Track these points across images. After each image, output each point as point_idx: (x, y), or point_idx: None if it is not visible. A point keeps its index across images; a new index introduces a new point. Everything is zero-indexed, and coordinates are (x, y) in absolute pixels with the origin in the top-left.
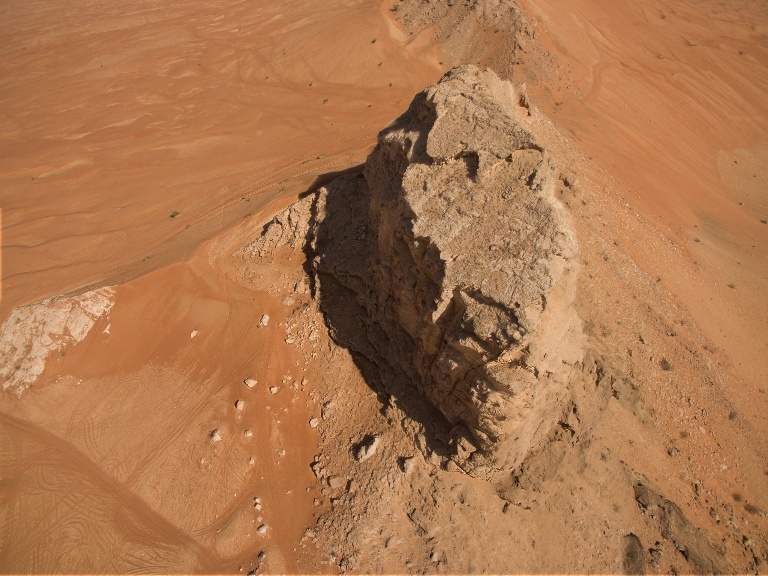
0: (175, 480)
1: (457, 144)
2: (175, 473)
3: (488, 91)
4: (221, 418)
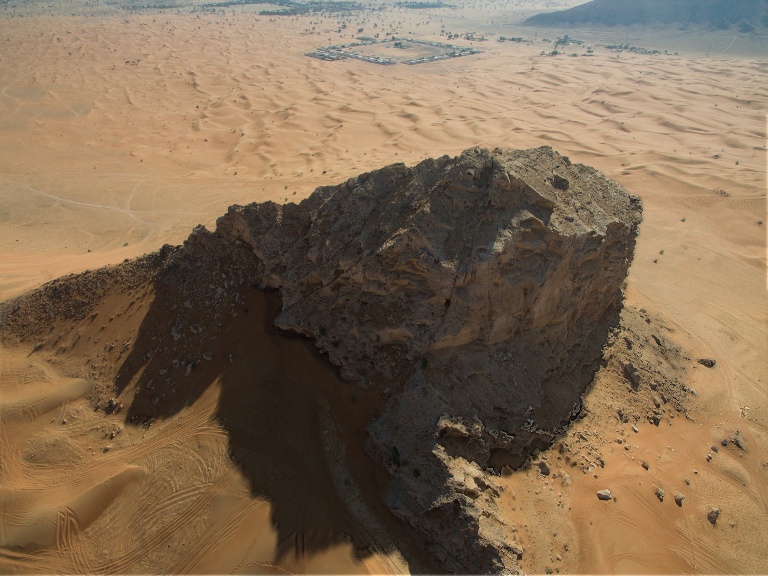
0: (762, 553)
1: (547, 184)
2: (760, 557)
3: (502, 150)
4: (699, 519)
